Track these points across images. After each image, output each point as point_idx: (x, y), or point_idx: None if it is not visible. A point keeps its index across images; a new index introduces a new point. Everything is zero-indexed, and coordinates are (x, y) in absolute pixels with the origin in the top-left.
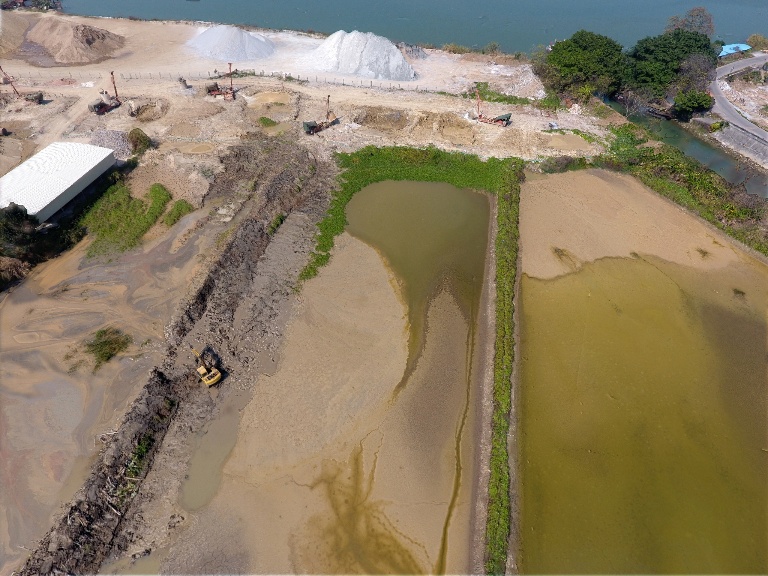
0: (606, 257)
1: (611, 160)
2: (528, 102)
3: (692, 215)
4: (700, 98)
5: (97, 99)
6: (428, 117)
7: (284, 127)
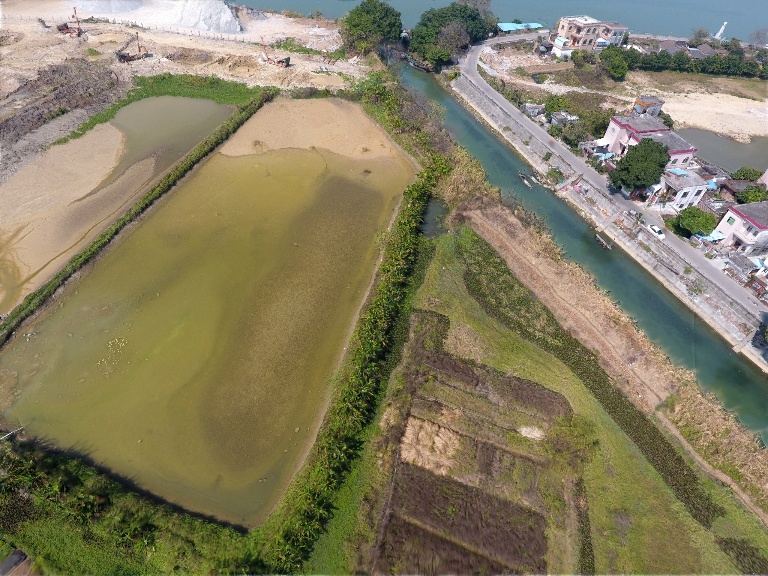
0: (290, 148)
1: (349, 92)
2: (319, 53)
3: (381, 129)
4: (439, 53)
5: None
6: (229, 58)
7: (105, 57)
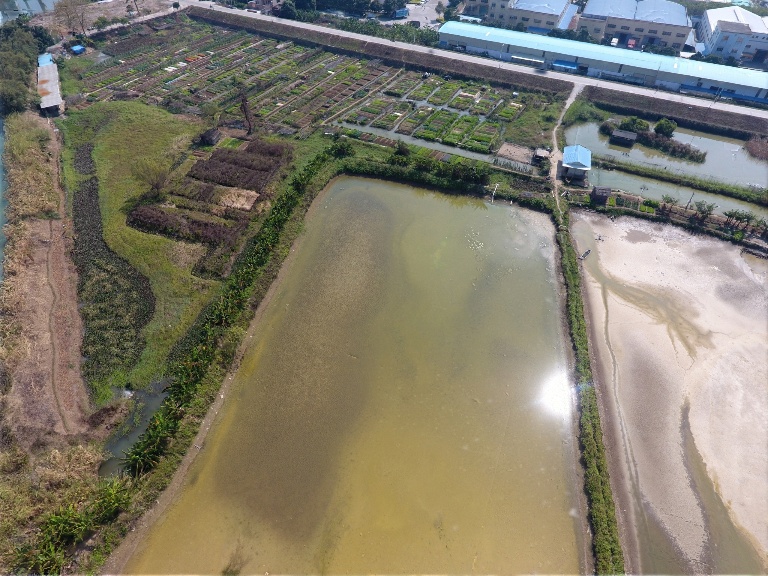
0: None
1: None
2: None
3: None
4: None
5: None
6: None
7: None
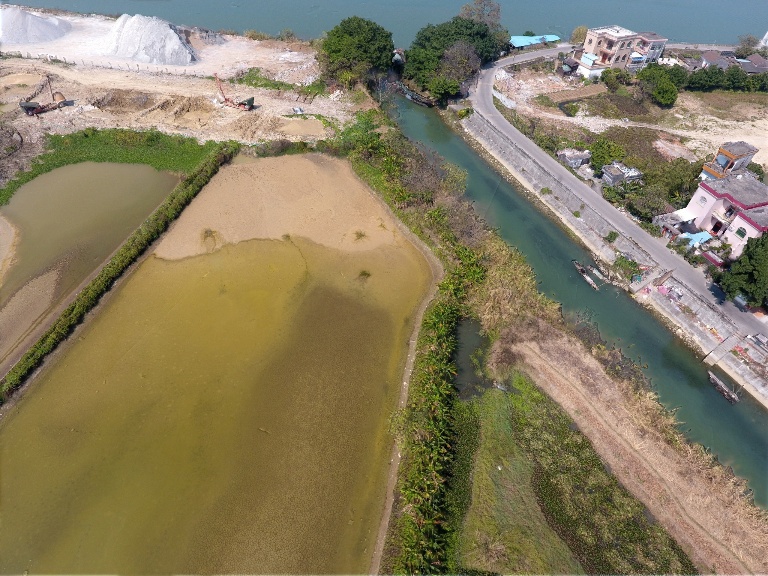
0: (254, 239)
1: (332, 145)
2: (291, 88)
3: (378, 199)
4: (445, 84)
5: None
6: (176, 101)
7: (8, 108)
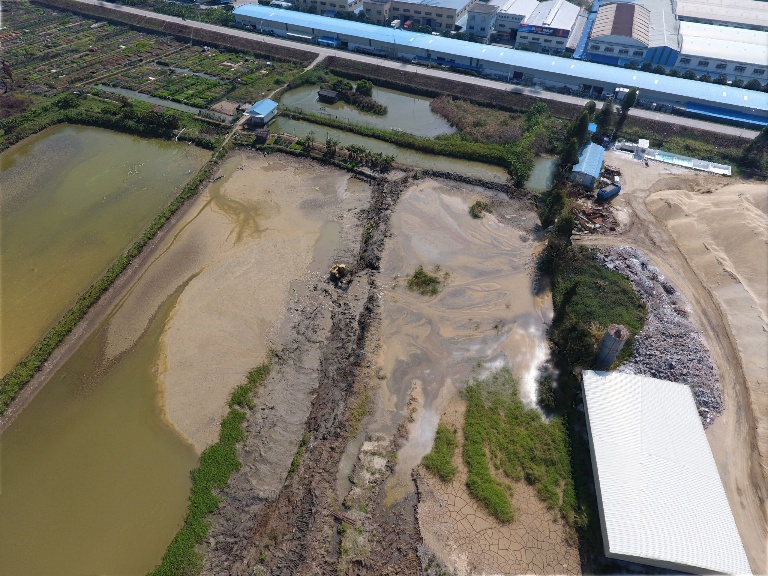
0: None
1: None
2: None
3: None
4: None
5: None
6: None
7: None
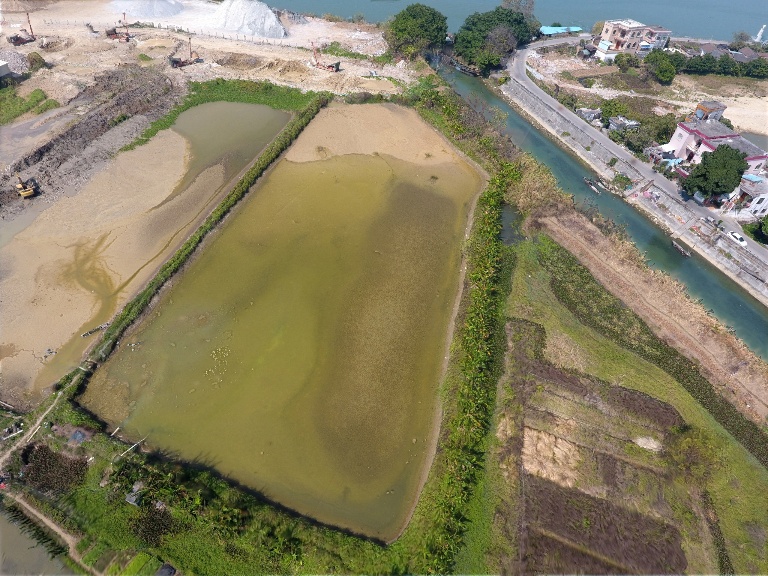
0: (353, 153)
1: (402, 97)
2: (366, 57)
3: (440, 134)
4: (489, 57)
5: (15, 33)
6: (278, 63)
7: (157, 62)
